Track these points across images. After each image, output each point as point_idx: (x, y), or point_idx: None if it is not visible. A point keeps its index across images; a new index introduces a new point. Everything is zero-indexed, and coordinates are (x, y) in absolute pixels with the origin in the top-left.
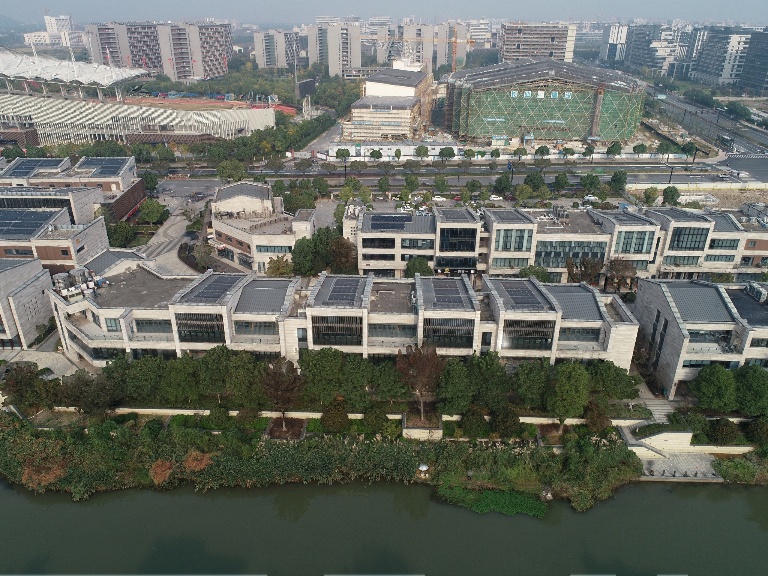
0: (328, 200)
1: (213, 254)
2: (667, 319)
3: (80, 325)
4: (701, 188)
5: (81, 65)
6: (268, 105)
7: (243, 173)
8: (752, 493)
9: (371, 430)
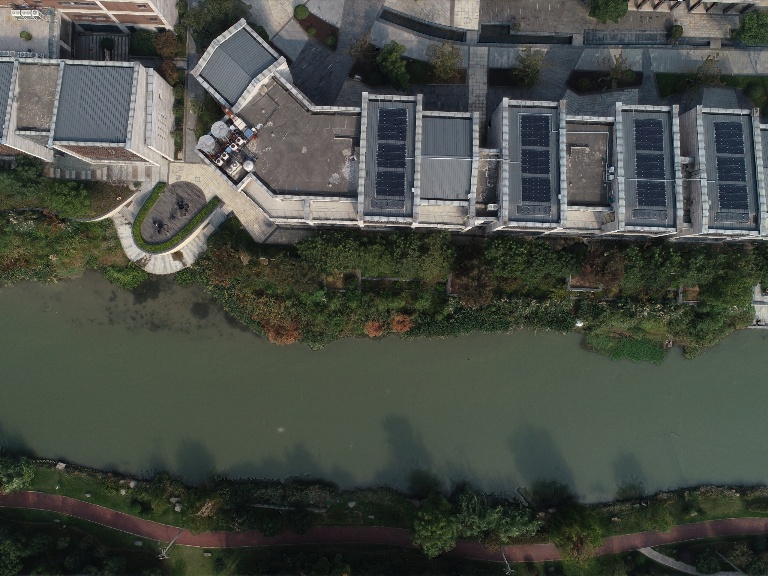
0: None
1: None
2: None
3: (246, 186)
4: None
5: None
6: None
7: None
8: None
9: None
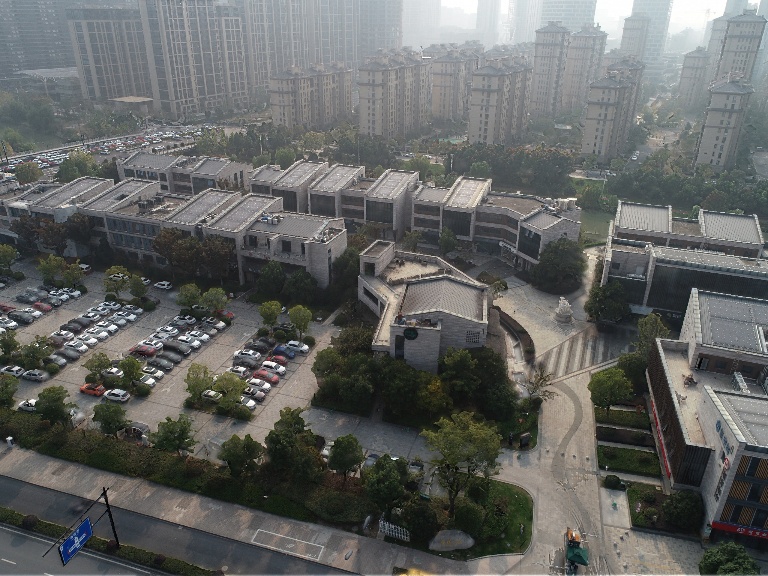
0: None
1: None
2: None
3: None
4: None
5: None
6: None
7: None
8: None
9: None
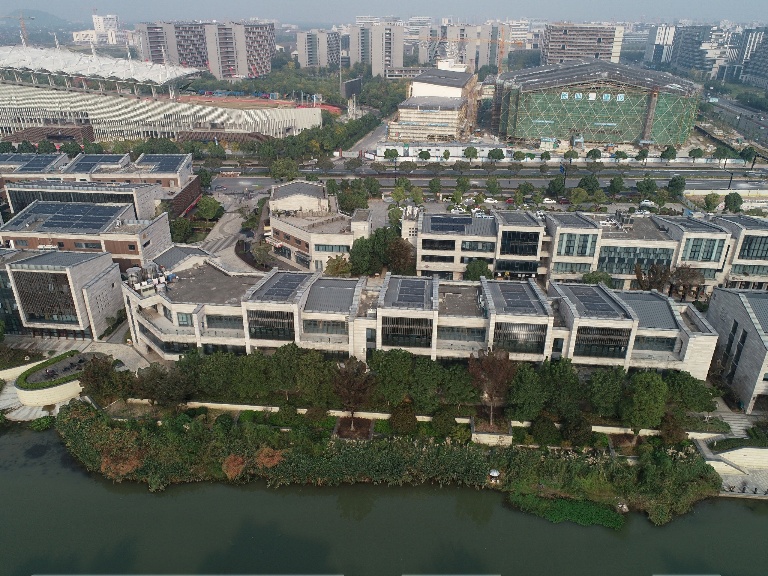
0: (379, 200)
1: (269, 252)
2: (746, 330)
3: (152, 319)
4: (762, 195)
5: (136, 63)
6: (313, 104)
7: None
8: None
9: (439, 433)
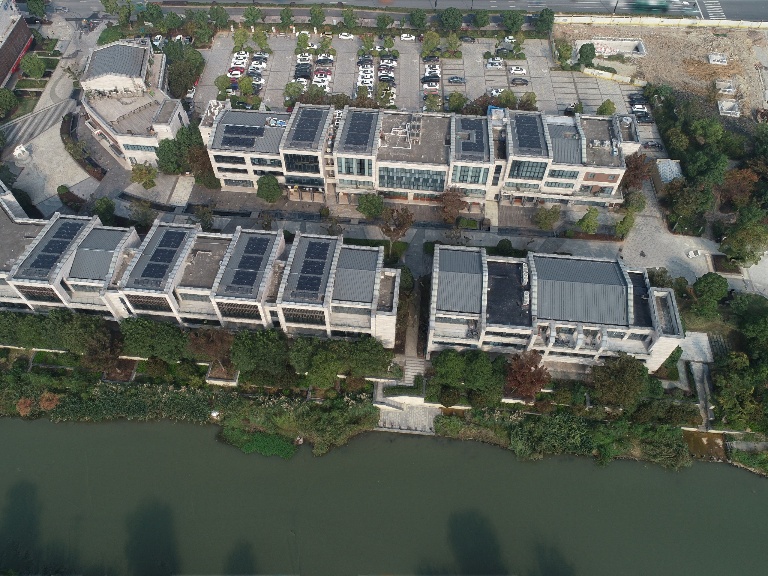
0: (228, 33)
1: None
2: None
3: None
4: (645, 23)
5: None
6: None
7: (130, 5)
8: (451, 446)
9: None
